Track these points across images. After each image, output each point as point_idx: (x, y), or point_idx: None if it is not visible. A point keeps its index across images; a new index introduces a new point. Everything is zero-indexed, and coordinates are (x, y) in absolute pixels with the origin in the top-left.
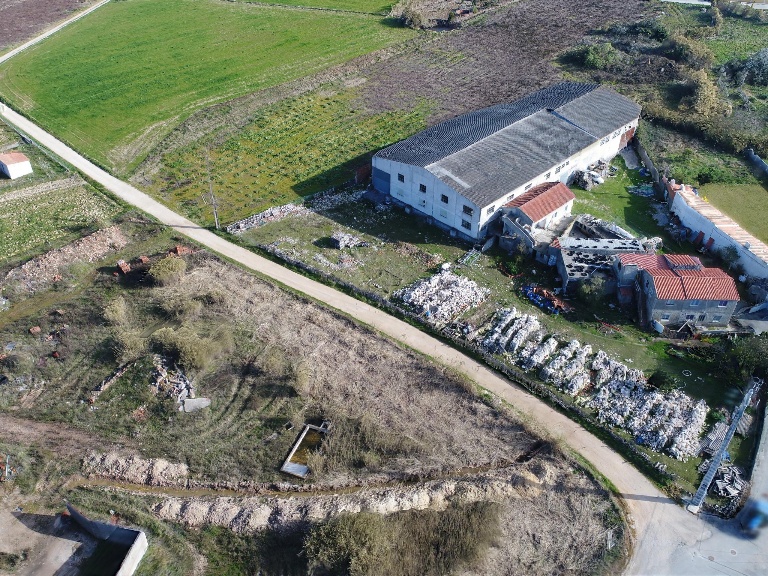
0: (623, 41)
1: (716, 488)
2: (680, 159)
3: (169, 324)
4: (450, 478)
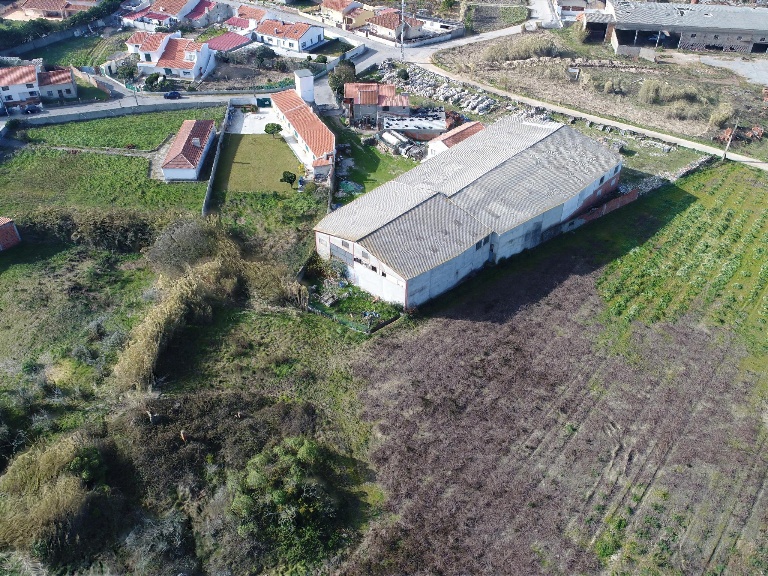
0: (175, 568)
1: (392, 63)
2: (287, 220)
3: (684, 98)
4: (505, 68)
